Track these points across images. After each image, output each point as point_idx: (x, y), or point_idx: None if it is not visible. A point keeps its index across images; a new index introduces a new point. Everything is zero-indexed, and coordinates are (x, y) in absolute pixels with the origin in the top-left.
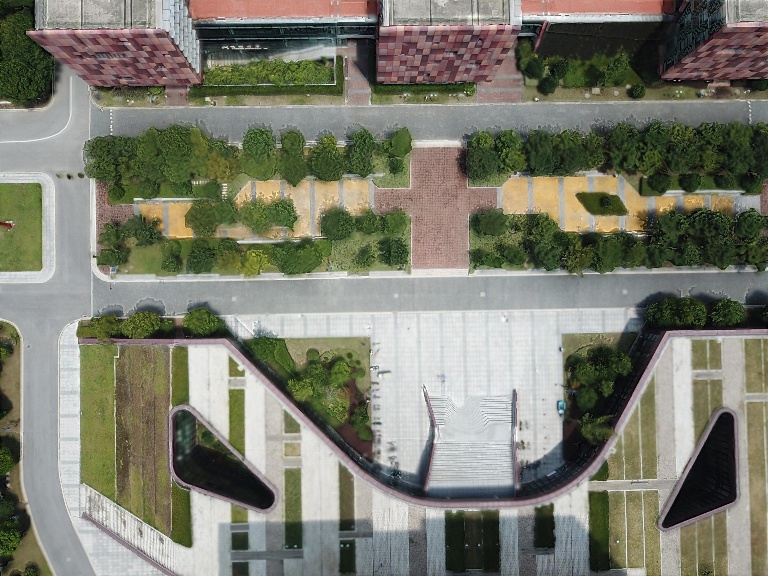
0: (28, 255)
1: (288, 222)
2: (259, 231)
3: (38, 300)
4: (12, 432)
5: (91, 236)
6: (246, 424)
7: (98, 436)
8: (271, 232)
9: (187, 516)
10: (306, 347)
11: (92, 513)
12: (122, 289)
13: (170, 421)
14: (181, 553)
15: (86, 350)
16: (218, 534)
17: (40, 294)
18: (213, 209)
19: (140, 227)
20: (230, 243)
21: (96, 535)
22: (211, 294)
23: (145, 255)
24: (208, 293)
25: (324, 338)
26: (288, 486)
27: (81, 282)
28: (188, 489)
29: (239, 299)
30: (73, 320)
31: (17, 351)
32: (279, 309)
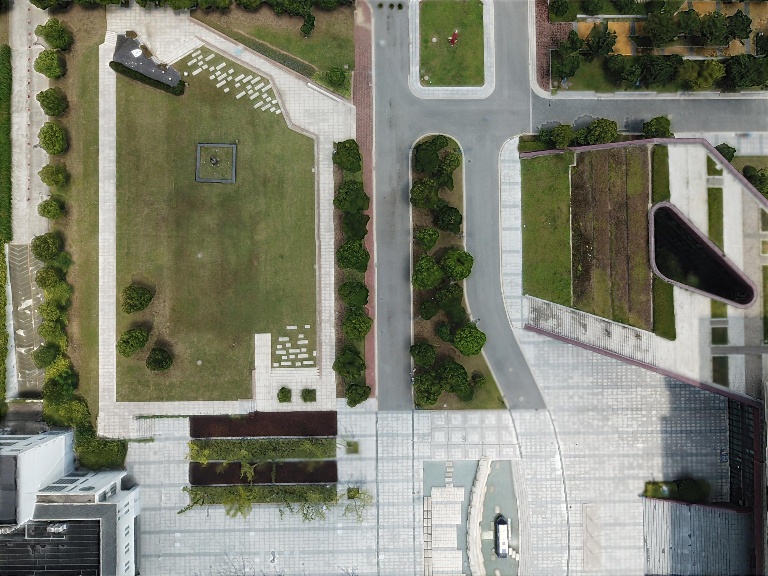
0: (470, 71)
1: (744, 33)
2: (715, 42)
3: (478, 116)
4: (456, 244)
5: (530, 54)
6: (724, 222)
7: (547, 246)
8: (707, 51)
9: (672, 309)
10: (742, 164)
11: (538, 323)
12: (560, 106)
13: (652, 217)
14: (663, 347)
15: (530, 164)
16: (698, 329)
17: (480, 110)
18: (680, 16)
19: (603, 35)
20: (680, 56)
21: (537, 346)
22: (647, 112)
23: (584, 72)
24: (645, 111)
25: (758, 156)
26: (767, 283)
27: (520, 99)
28: (672, 283)
29: (675, 117)
30: (512, 136)
31: (460, 165)
32: (713, 127)
